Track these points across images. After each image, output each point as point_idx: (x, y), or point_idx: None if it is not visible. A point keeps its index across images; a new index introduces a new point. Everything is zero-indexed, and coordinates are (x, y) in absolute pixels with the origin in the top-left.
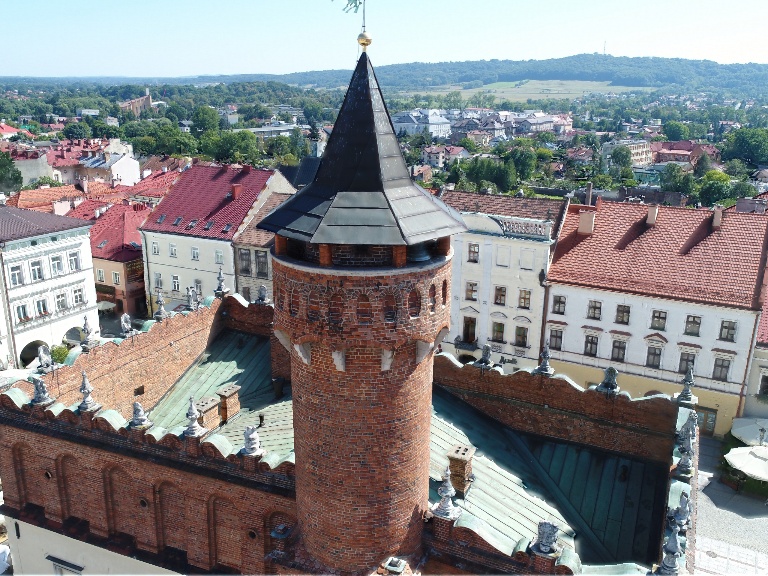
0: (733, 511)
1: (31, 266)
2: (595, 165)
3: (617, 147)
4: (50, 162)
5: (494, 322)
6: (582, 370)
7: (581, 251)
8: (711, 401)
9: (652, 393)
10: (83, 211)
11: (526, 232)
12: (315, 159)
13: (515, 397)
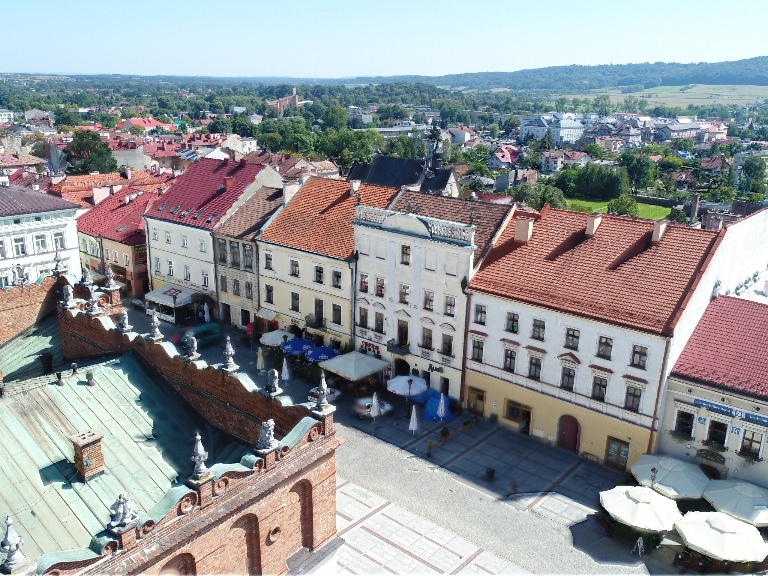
0: (588, 553)
1: (14, 242)
2: (723, 176)
3: (749, 157)
4: (151, 153)
5: (424, 327)
6: (501, 385)
7: (511, 259)
8: (623, 433)
9: (568, 417)
10: (119, 197)
11: (451, 236)
12: (388, 158)
13: (209, 392)
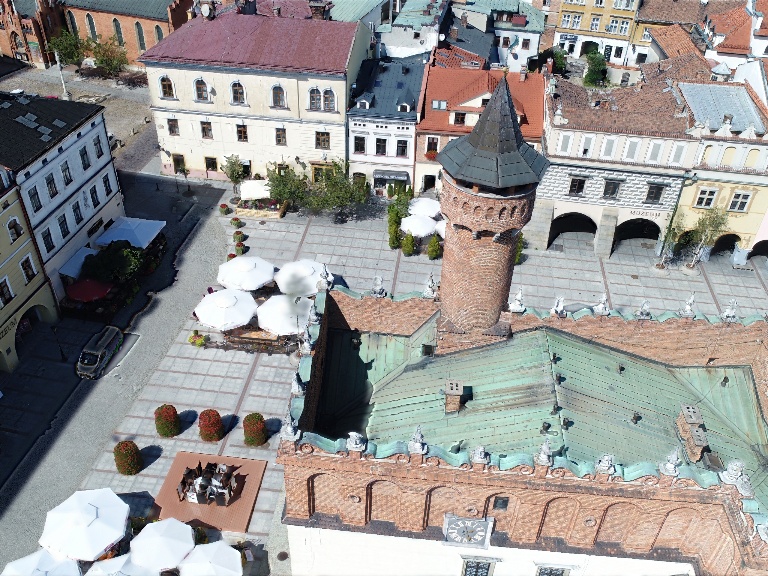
0: None
1: None
2: None
3: None
4: None
5: None
6: None
7: None
8: None
9: None
10: None
11: None
12: None
13: None
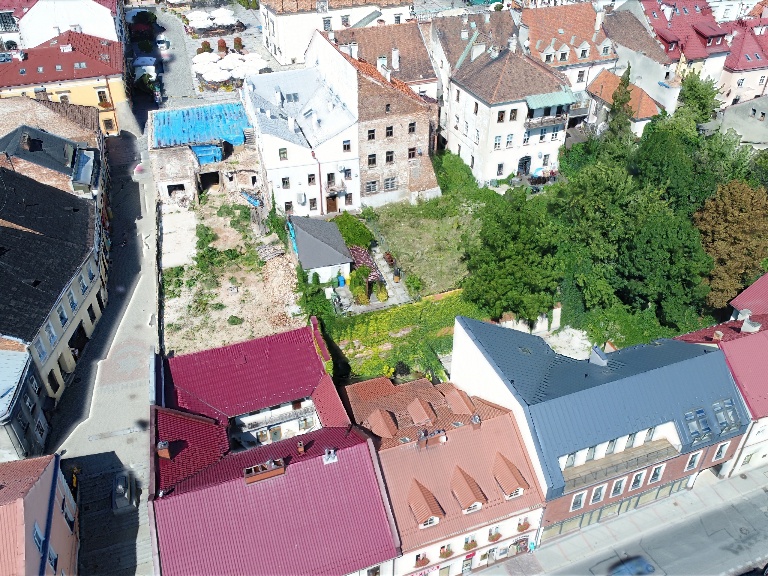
0: None
1: None
2: None
3: None
4: None
5: None
6: None
7: None
8: None
9: None
10: None
11: (424, 19)
12: None
13: None
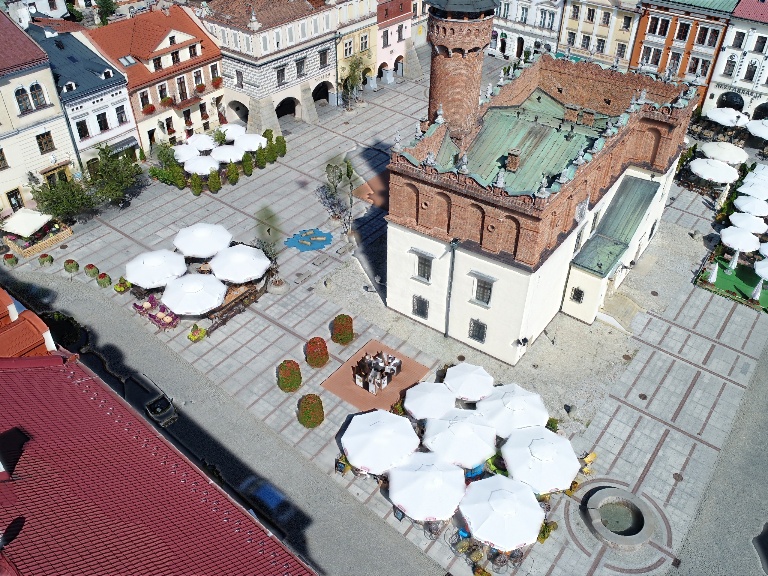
0: (764, 533)
1: None
2: None
3: None
4: None
5: None
6: None
7: None
8: None
9: None
10: None
11: None
12: None
13: None
